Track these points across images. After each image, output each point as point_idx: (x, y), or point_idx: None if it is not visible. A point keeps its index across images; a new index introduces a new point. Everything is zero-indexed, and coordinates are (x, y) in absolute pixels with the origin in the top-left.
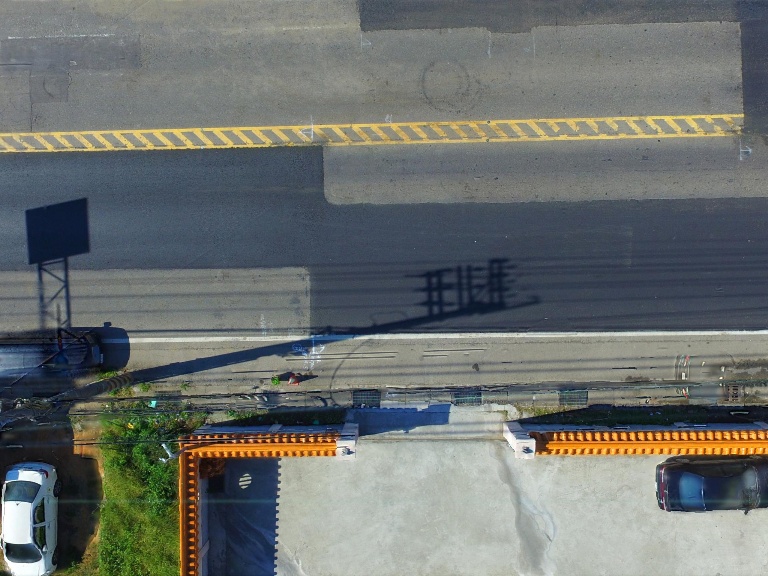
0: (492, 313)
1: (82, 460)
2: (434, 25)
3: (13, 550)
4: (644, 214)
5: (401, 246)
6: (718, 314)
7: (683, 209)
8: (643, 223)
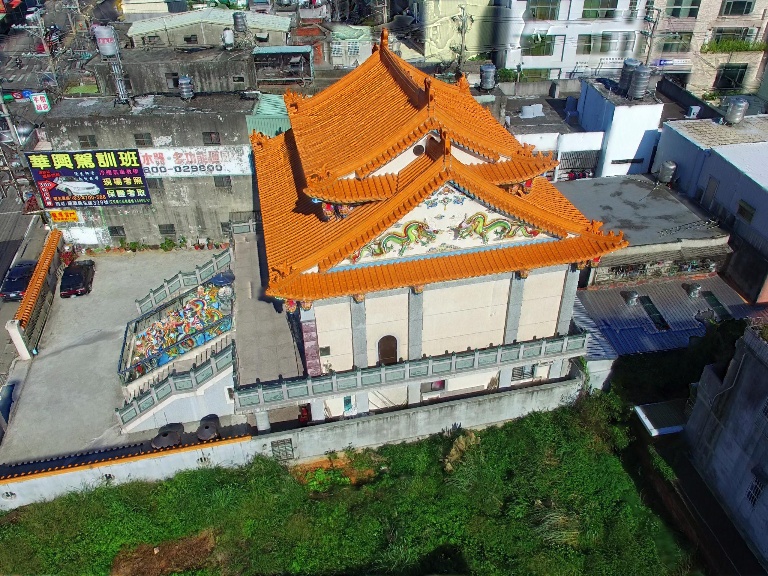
0: None
1: None
2: None
3: None
4: None
5: None
6: None
7: None
8: None
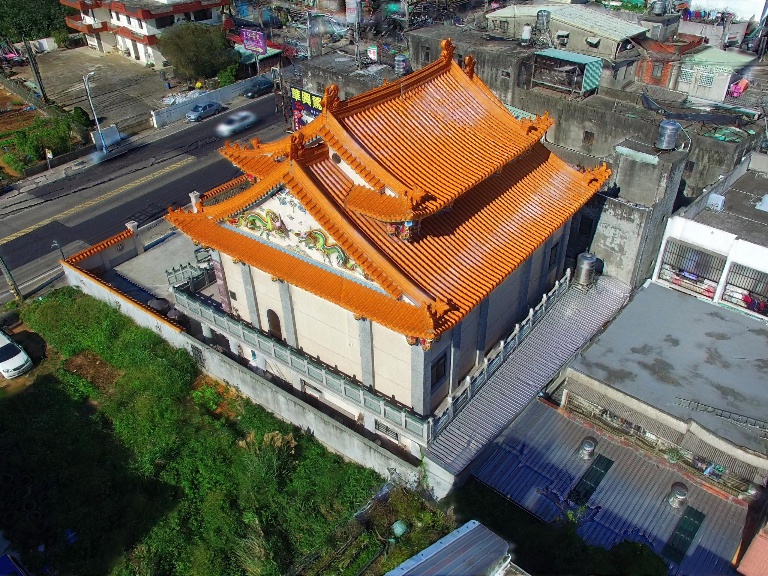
0: None
1: (17, 334)
2: (73, 189)
3: (1, 357)
4: None
5: (111, 219)
6: None
7: None
8: None
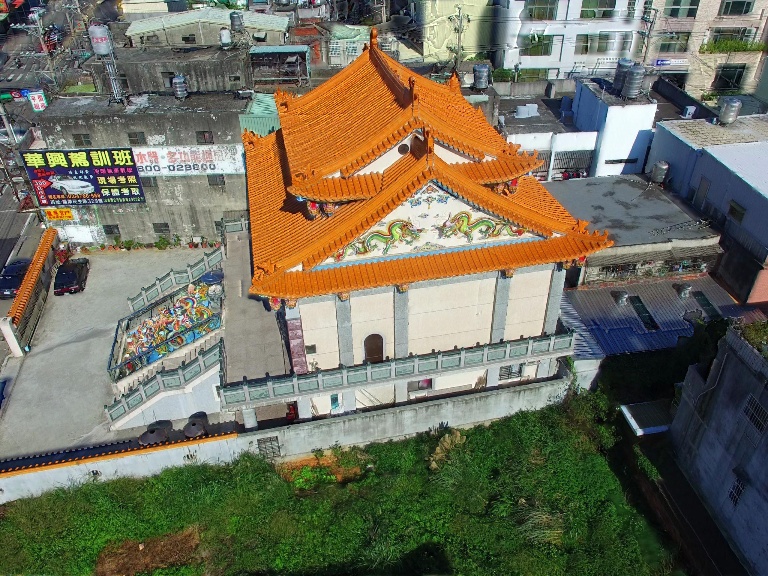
0: None
1: None
2: None
3: None
4: None
5: None
6: None
7: None
8: None
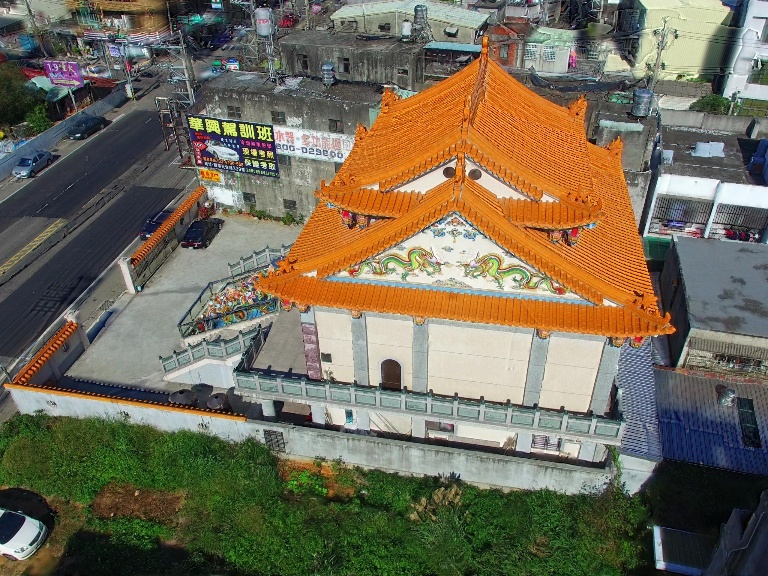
0: (73, 292)
1: None
2: None
3: (2, 536)
4: (74, 245)
5: (8, 317)
6: (135, 231)
7: (82, 235)
8: (77, 245)
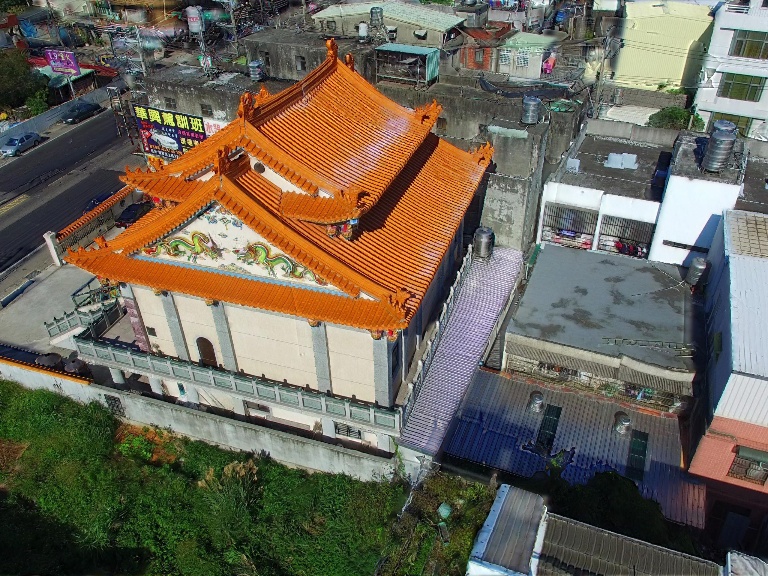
0: None
1: None
2: None
3: None
4: None
5: None
6: None
7: None
8: None
